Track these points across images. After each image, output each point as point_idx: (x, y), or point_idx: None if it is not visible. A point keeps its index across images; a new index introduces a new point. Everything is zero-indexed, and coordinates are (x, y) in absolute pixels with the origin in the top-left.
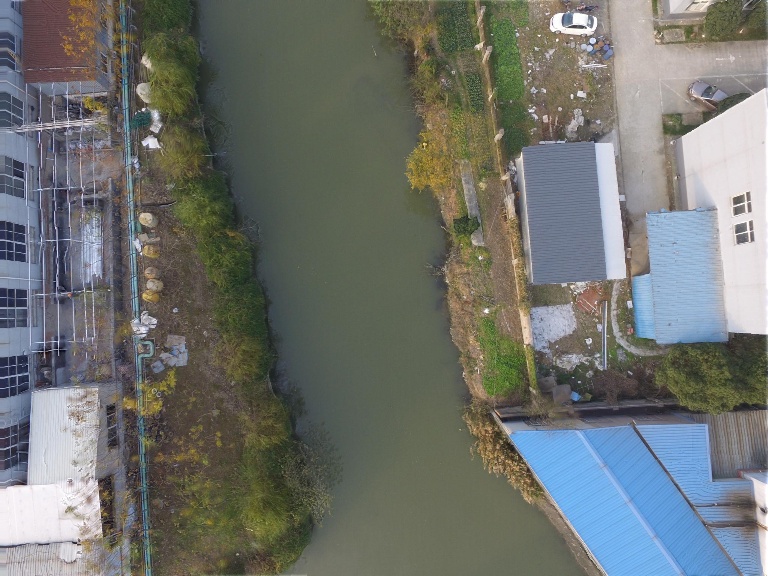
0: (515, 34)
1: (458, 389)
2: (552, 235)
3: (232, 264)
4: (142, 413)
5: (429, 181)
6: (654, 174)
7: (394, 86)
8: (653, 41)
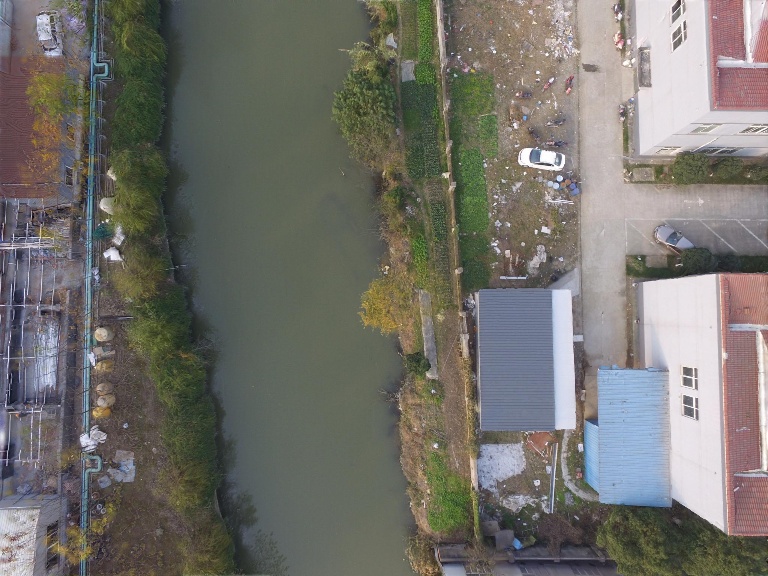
0: (483, 165)
1: (404, 518)
2: (503, 382)
3: (183, 387)
4: (85, 529)
5: (380, 325)
6: (614, 316)
7: (360, 207)
8: (622, 179)
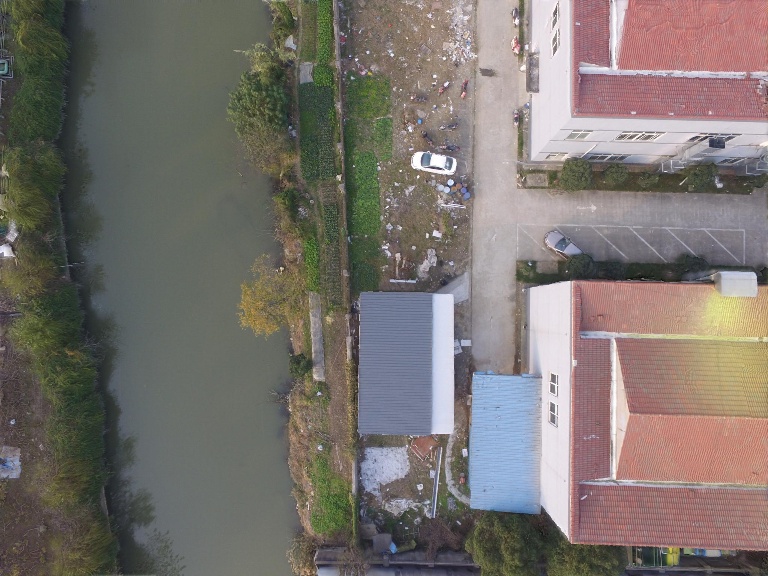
0: (377, 167)
1: (291, 520)
2: (381, 385)
3: (67, 384)
4: None
5: (255, 326)
6: (503, 321)
7: (256, 208)
8: (515, 184)
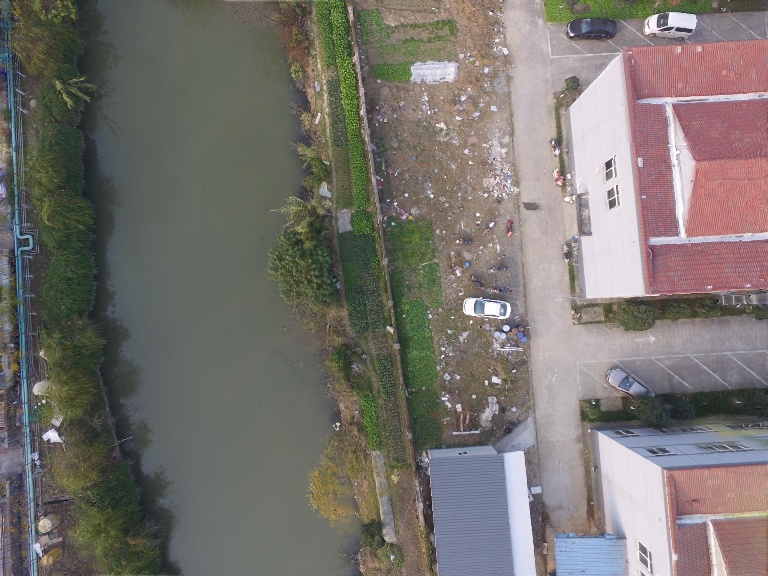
0: (428, 316)
1: None
2: (460, 553)
3: None
4: None
5: None
6: (571, 464)
7: (305, 364)
8: (570, 321)
